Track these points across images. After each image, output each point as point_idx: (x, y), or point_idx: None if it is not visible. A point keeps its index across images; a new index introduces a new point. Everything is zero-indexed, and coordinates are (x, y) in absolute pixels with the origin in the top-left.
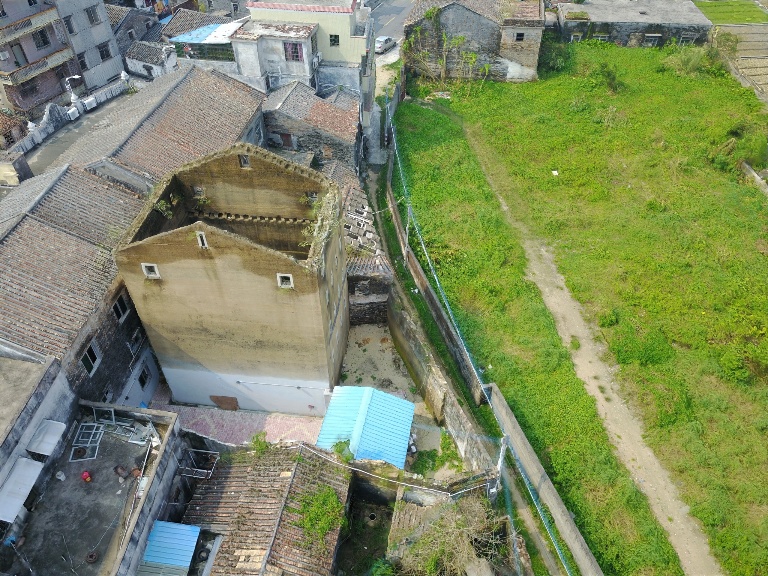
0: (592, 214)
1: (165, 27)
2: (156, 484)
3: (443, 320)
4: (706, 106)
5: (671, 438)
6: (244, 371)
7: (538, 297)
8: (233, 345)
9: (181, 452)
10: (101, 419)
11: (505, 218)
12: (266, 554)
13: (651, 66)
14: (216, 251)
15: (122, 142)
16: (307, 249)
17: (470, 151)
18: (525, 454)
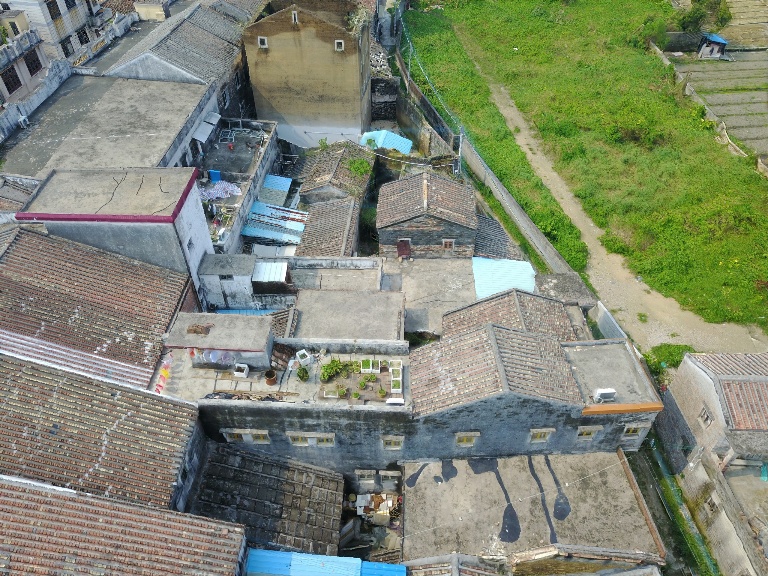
0: (538, 70)
1: None
2: None
3: (431, 111)
4: (633, 12)
5: (569, 166)
6: (309, 123)
7: (495, 108)
8: (305, 100)
9: (277, 153)
10: (233, 128)
11: (478, 73)
12: (332, 175)
13: None
14: (302, 25)
15: None
16: None
17: (456, 38)
18: (478, 164)
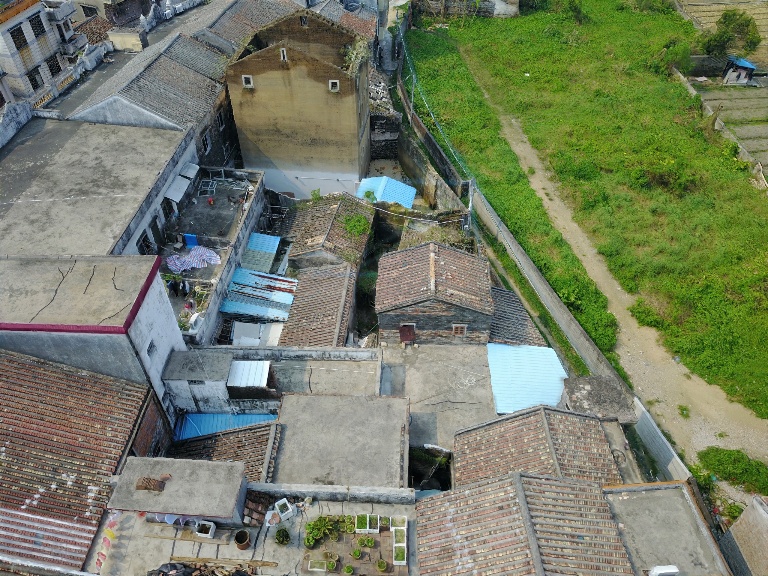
0: (552, 99)
1: None
2: (255, 204)
3: (437, 150)
4: (652, 33)
5: (591, 216)
6: (301, 167)
7: (507, 145)
8: (296, 144)
9: (264, 205)
10: (215, 177)
11: (486, 102)
12: (325, 236)
13: (613, 6)
14: (292, 63)
15: (214, 21)
16: (348, 67)
17: (462, 62)
18: (489, 216)
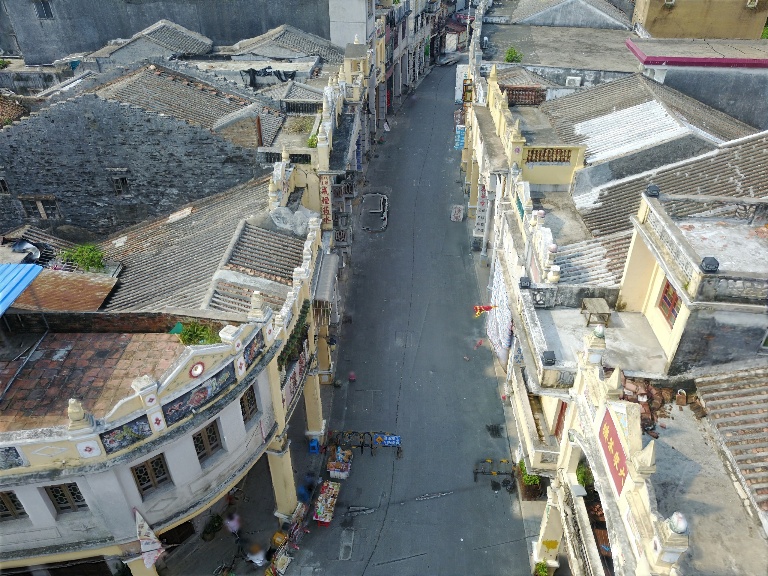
0: None
1: None
2: None
3: None
4: None
5: None
6: None
7: None
8: None
9: None
10: None
11: None
12: None
13: None
14: None
15: None
16: None
17: None
18: None
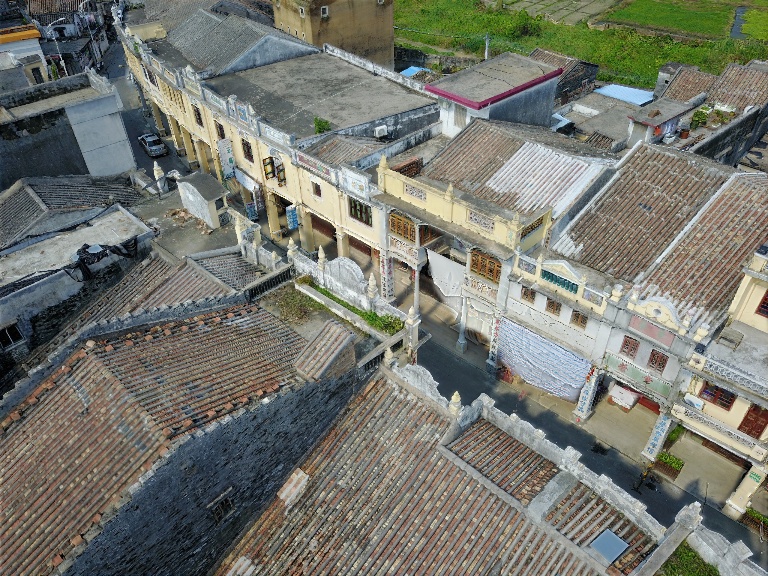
0: None
1: (29, 10)
2: None
3: None
4: None
5: None
6: None
7: None
8: None
9: None
10: None
11: None
12: None
13: None
14: None
15: None
16: None
17: None
18: None
